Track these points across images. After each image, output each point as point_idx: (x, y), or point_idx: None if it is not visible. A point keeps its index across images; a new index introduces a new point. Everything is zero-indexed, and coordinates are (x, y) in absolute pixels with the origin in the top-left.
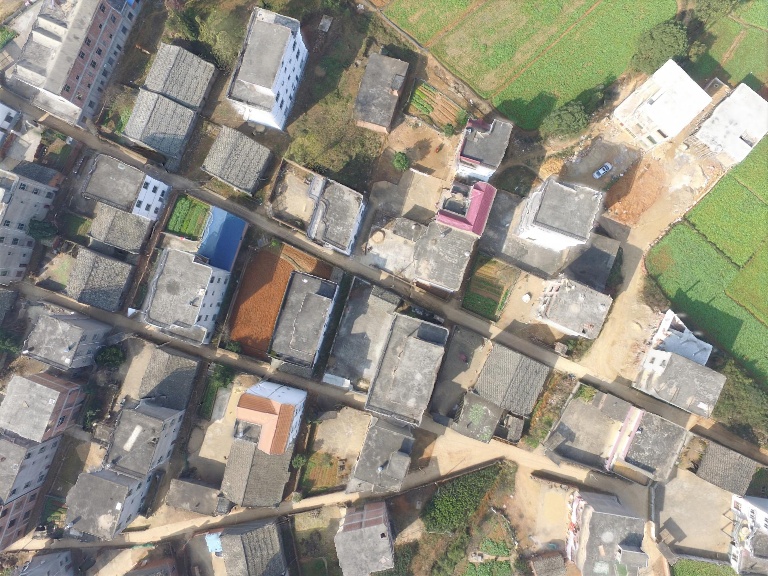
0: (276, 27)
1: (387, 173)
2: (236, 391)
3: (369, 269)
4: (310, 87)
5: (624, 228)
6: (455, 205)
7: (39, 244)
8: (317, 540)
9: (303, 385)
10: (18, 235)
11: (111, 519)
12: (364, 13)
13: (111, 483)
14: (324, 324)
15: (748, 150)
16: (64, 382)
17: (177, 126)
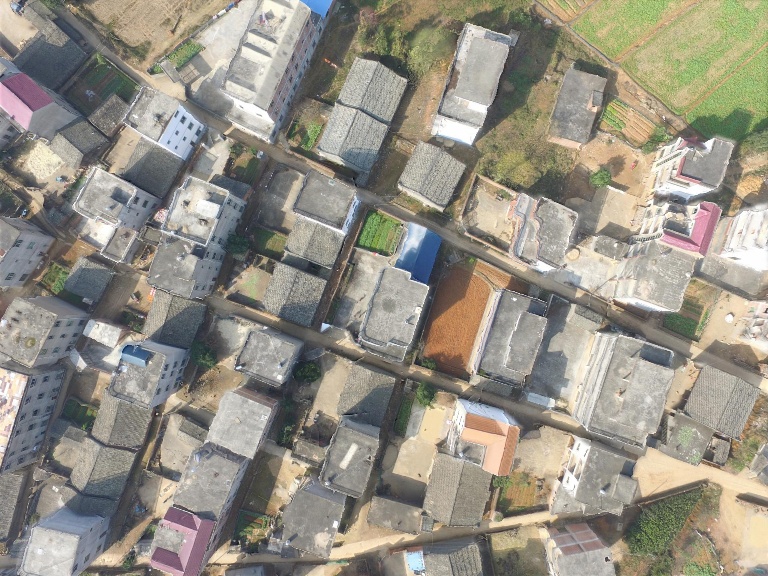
0: (493, 44)
1: (580, 190)
2: (430, 408)
3: (564, 287)
4: (498, 102)
5: None
6: (674, 225)
7: (230, 258)
8: (515, 560)
9: (498, 403)
10: (217, 249)
11: (328, 537)
12: (551, 27)
13: (327, 501)
14: None
15: None
16: (264, 397)
17: (372, 141)
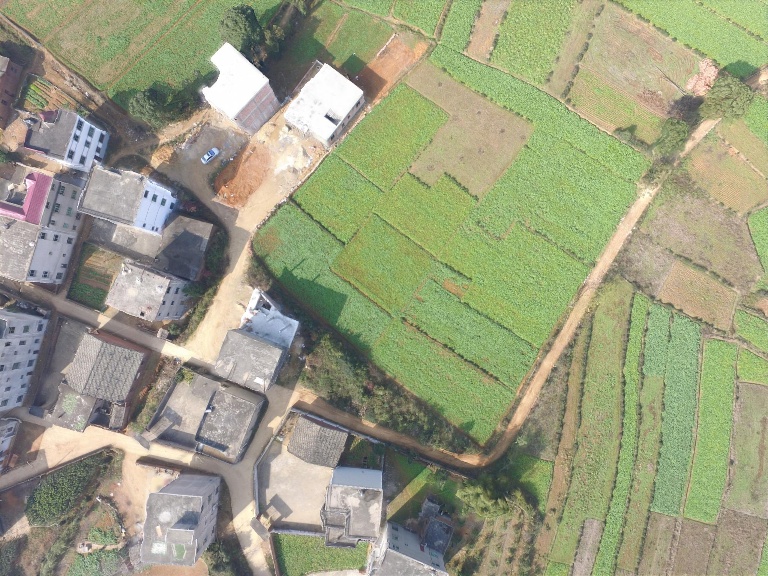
0: None
1: (0, 169)
2: None
3: None
4: None
5: (233, 211)
6: (22, 196)
7: None
8: None
9: None
10: None
11: None
12: None
13: None
14: None
15: (333, 128)
16: None
17: None
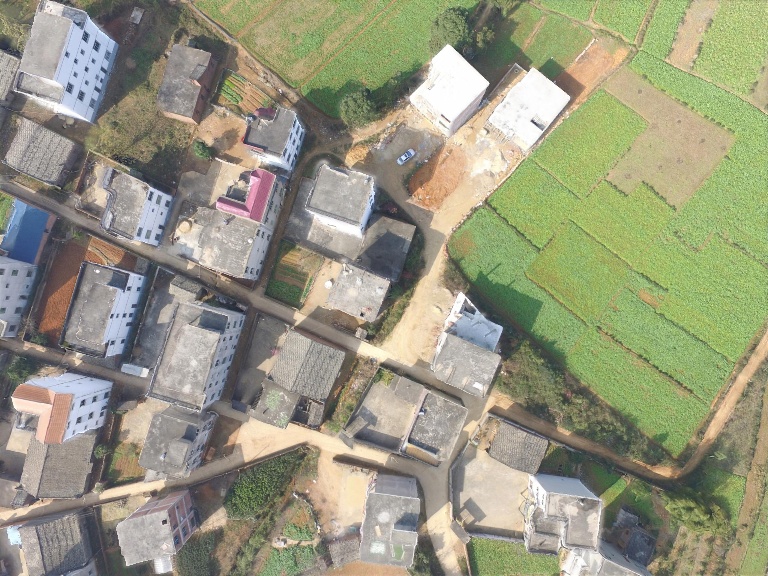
0: (57, 18)
1: (196, 163)
2: None
3: (176, 259)
4: (121, 79)
5: (428, 213)
6: (239, 192)
7: None
8: None
9: (110, 376)
10: None
11: None
12: (176, 5)
13: None
14: (119, 314)
15: (539, 134)
16: None
17: None
